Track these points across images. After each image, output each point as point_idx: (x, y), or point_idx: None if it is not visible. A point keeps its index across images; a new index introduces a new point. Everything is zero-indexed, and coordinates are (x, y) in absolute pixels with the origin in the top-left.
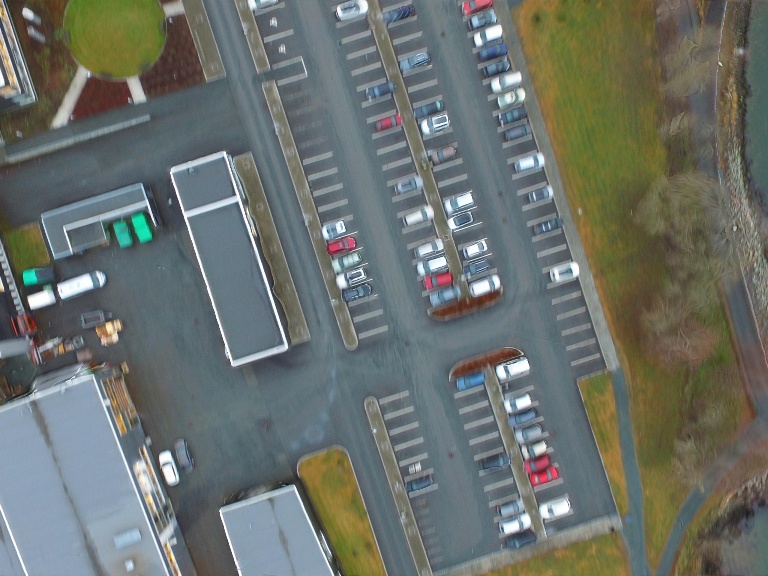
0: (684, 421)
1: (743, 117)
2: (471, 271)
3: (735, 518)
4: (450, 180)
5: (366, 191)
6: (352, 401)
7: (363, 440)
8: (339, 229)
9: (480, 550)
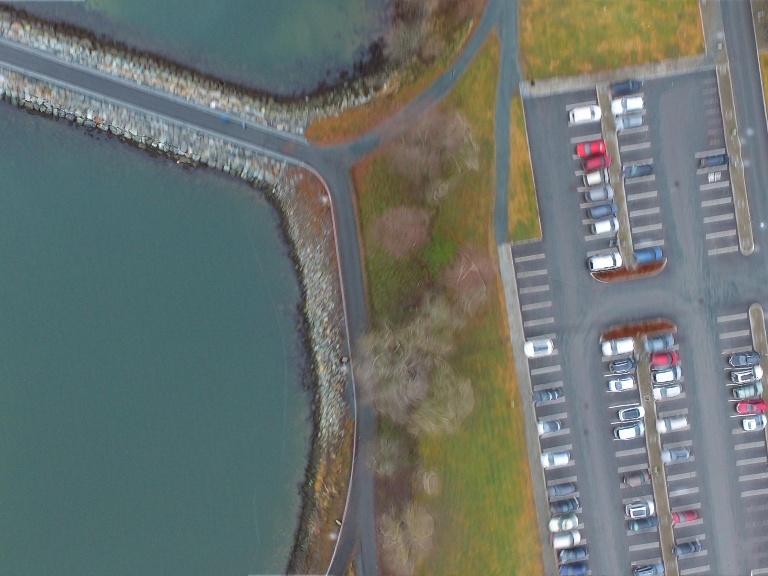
0: (443, 181)
1: (311, 465)
2: (632, 363)
3: (376, 65)
4: (634, 453)
5: (716, 455)
6: (765, 254)
7: (762, 213)
8: (754, 424)
9: (666, 84)
